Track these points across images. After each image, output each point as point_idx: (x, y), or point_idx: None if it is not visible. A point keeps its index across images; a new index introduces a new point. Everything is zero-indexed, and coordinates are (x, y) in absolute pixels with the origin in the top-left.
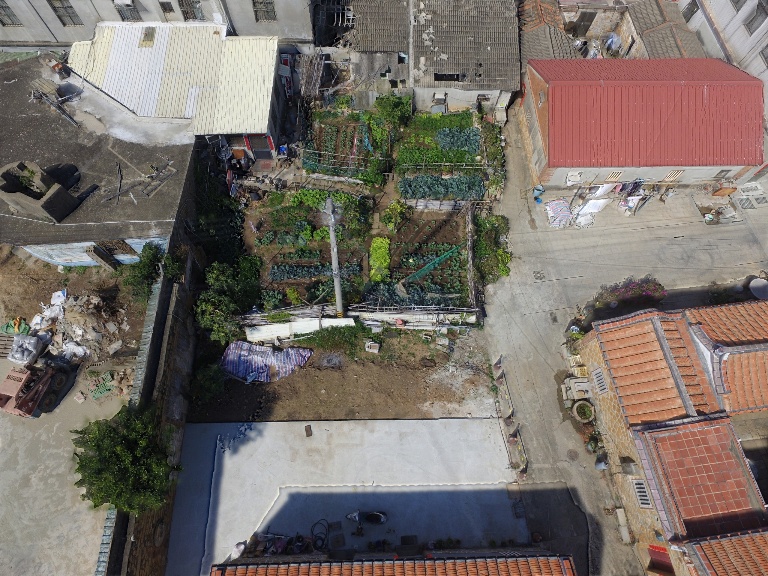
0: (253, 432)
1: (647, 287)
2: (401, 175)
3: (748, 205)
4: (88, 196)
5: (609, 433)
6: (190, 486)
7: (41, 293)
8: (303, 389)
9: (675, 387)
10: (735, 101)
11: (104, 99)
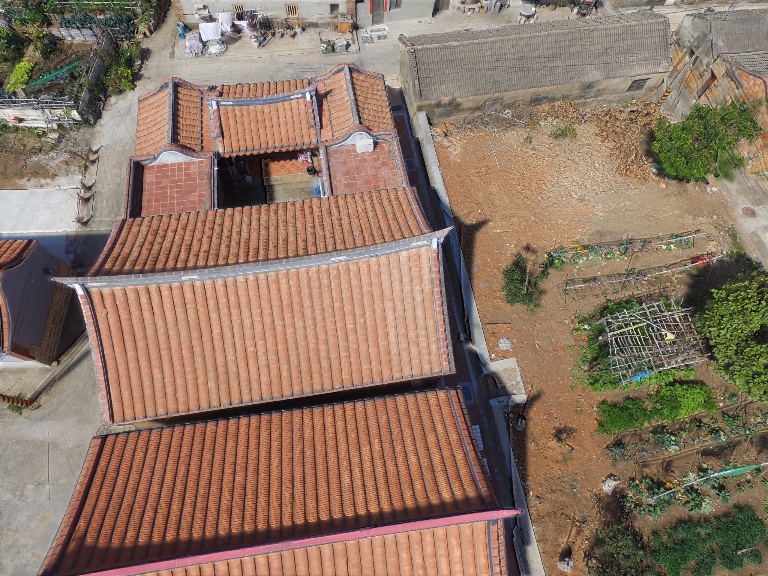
0: None
1: None
2: (60, 15)
3: (369, 41)
4: None
5: None
6: None
7: None
8: None
9: None
10: None
11: None
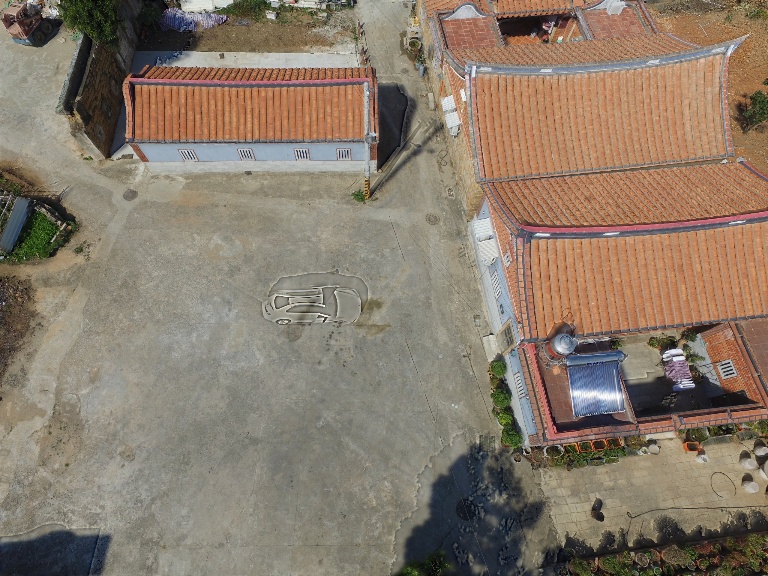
0: (183, 56)
1: None
2: None
3: None
4: None
5: (427, 50)
6: None
7: None
8: (220, 35)
9: None
10: None
11: None
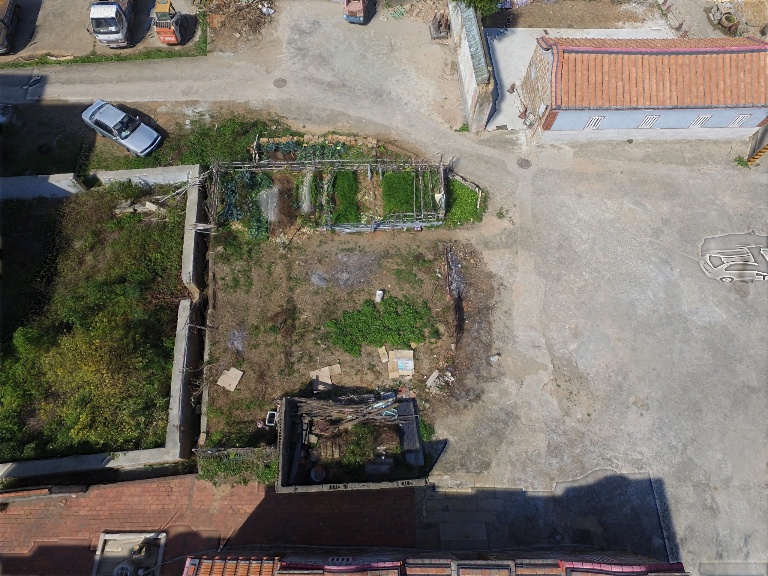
0: (509, 32)
1: None
2: None
3: None
4: None
5: (750, 24)
6: None
7: None
8: (537, 12)
9: None
10: None
11: None
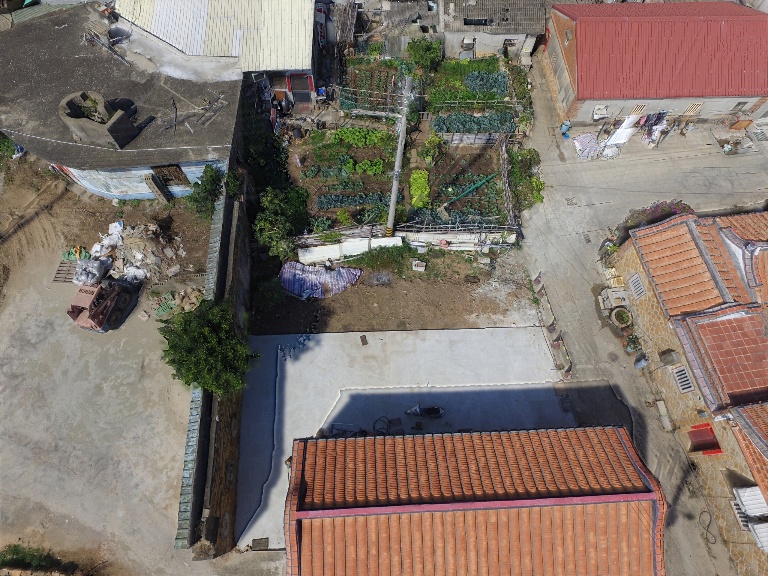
0: (311, 342)
1: (675, 206)
2: (435, 113)
3: (763, 138)
4: (146, 126)
5: (647, 333)
6: (256, 390)
7: (98, 225)
8: (356, 304)
9: (711, 280)
10: (751, 35)
11: (153, 41)
